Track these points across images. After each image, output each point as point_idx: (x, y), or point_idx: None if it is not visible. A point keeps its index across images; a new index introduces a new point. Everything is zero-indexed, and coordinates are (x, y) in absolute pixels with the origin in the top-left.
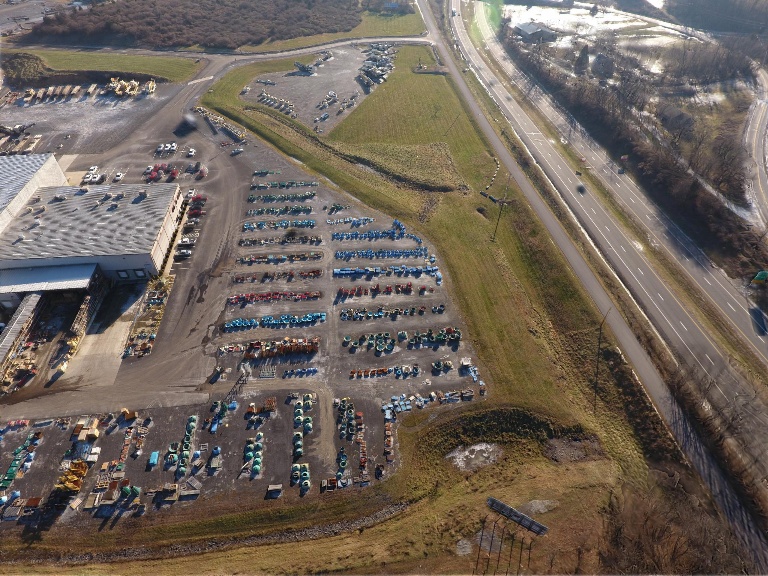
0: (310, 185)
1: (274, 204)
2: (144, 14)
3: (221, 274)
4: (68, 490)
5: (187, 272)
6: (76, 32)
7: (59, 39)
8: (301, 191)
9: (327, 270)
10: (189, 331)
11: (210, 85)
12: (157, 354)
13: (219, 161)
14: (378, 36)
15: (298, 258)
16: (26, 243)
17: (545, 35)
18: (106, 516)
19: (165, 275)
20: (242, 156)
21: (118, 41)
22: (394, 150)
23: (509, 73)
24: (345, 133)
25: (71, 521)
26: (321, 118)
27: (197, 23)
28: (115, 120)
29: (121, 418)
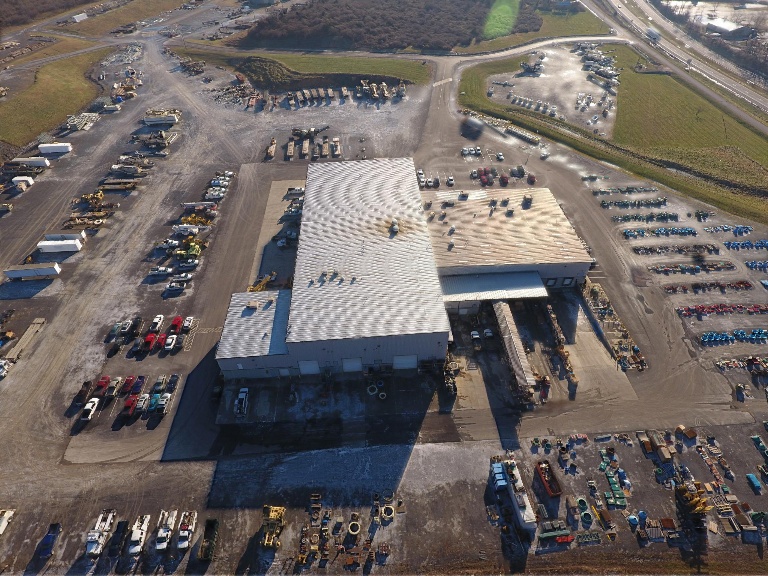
0: (650, 190)
1: (632, 210)
2: (349, 16)
3: (645, 284)
4: (695, 512)
5: (608, 281)
6: (294, 35)
7: (278, 42)
8: (647, 197)
9: (753, 281)
10: (667, 344)
11: (456, 87)
12: (656, 368)
13: (535, 165)
14: (571, 35)
15: (712, 268)
16: (461, 249)
17: (746, 32)
18: (756, 542)
19: (589, 284)
20: (553, 160)
21: (336, 44)
22: (690, 154)
23: (737, 72)
24: (627, 136)
25: (723, 546)
26: (592, 120)
27: (398, 25)
28: (392, 123)
29: (679, 436)
